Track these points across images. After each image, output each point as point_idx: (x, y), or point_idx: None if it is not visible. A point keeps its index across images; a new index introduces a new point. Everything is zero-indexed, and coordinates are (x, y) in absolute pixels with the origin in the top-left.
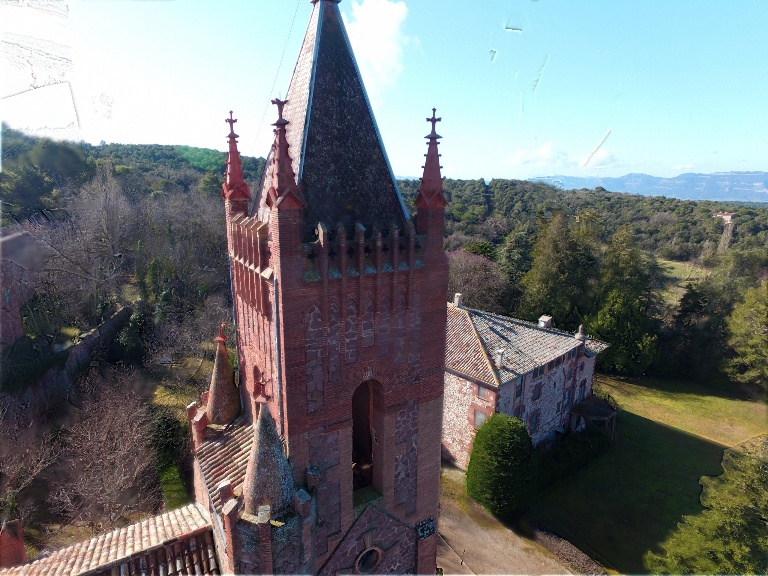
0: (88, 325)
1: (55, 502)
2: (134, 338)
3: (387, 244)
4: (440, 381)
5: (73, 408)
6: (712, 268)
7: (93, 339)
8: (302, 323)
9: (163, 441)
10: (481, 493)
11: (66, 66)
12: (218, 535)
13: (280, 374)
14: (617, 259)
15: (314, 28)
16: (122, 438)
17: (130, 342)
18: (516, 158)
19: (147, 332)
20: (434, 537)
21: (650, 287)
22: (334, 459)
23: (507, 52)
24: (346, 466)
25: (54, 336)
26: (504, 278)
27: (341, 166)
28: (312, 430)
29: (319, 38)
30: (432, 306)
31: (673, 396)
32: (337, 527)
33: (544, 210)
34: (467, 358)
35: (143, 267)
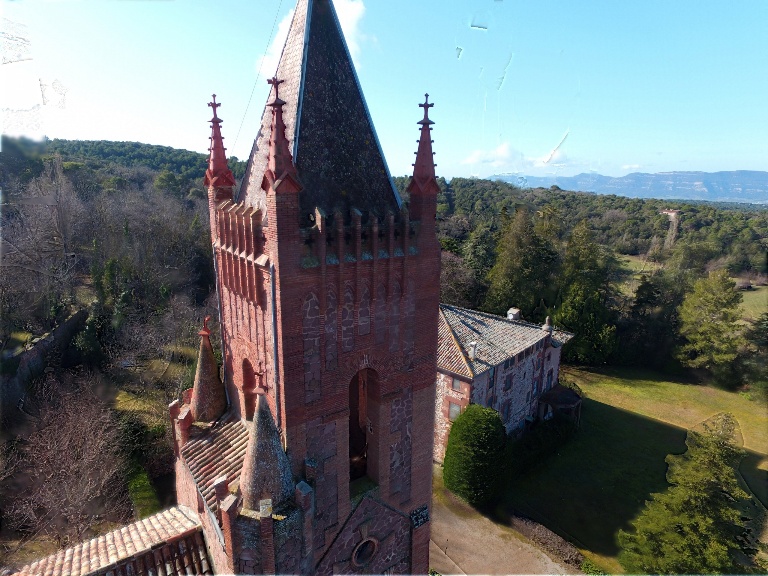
0: (41, 329)
1: (12, 517)
2: (92, 342)
3: (383, 230)
4: (433, 368)
5: (27, 418)
6: (664, 261)
7: (47, 344)
8: (300, 311)
9: (130, 447)
10: (458, 483)
11: (22, 47)
12: (210, 535)
13: (277, 364)
14: (577, 253)
15: (304, 9)
16: (85, 446)
17: (87, 346)
18: (481, 155)
19: (107, 335)
20: (427, 525)
21: (608, 280)
22: (331, 450)
23: (473, 50)
24: (343, 457)
25: (3, 341)
26: (471, 273)
27: (334, 151)
28: (310, 421)
29: (310, 19)
30: (425, 293)
31: (631, 383)
32: (334, 519)
33: (507, 207)
34: (441, 351)
35: (99, 267)
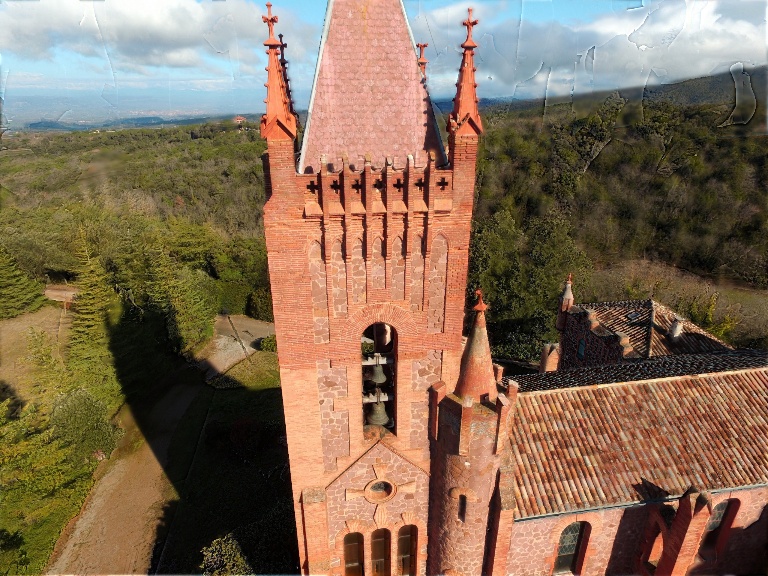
0: None
1: None
2: None
3: None
4: None
5: None
6: None
7: None
8: None
9: None
10: None
11: None
12: None
13: None
14: None
15: None
16: None
17: None
18: None
19: None
20: None
21: None
22: None
23: None
24: None
25: None
26: None
27: None
28: None
29: None
30: None
31: None
32: None
33: None
34: None
35: None
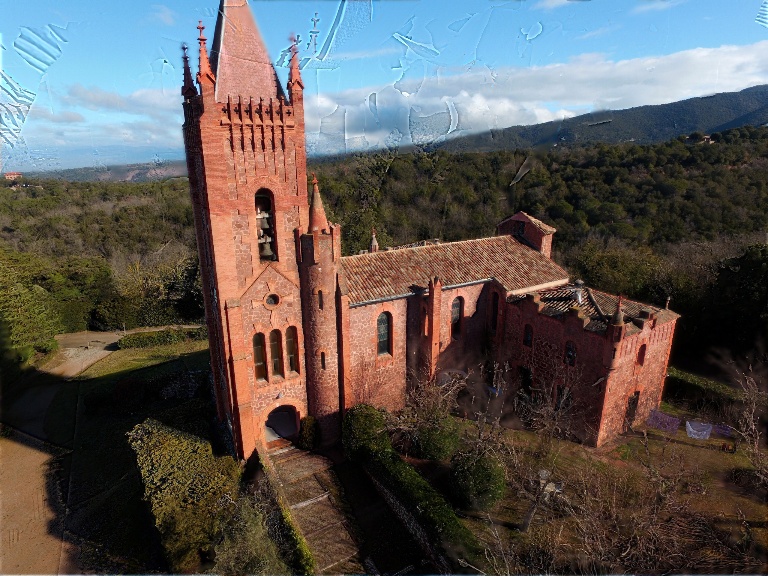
0: None
1: None
2: None
3: None
4: None
5: None
6: None
7: None
8: None
9: None
10: None
11: None
12: None
13: None
14: None
15: None
16: None
17: None
18: None
19: None
20: None
21: None
22: None
23: None
24: None
25: None
26: None
27: None
28: None
29: None
30: None
31: None
32: None
33: None
34: None
35: None
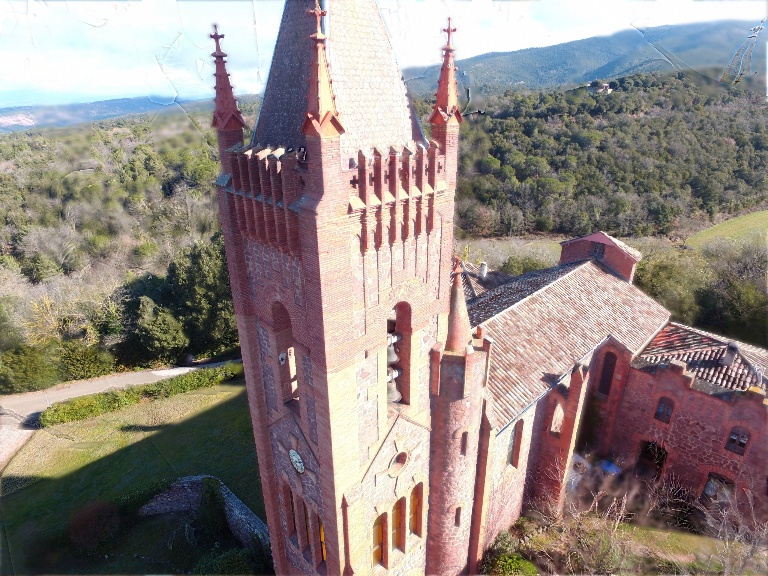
0: None
1: None
2: None
3: None
4: None
5: None
6: None
7: None
8: None
9: None
10: None
11: None
12: None
13: None
14: None
15: None
16: None
17: None
18: None
19: None
20: None
21: None
22: None
23: None
24: None
25: None
26: None
27: None
28: None
29: None
30: None
31: None
32: None
33: None
34: None
35: None
